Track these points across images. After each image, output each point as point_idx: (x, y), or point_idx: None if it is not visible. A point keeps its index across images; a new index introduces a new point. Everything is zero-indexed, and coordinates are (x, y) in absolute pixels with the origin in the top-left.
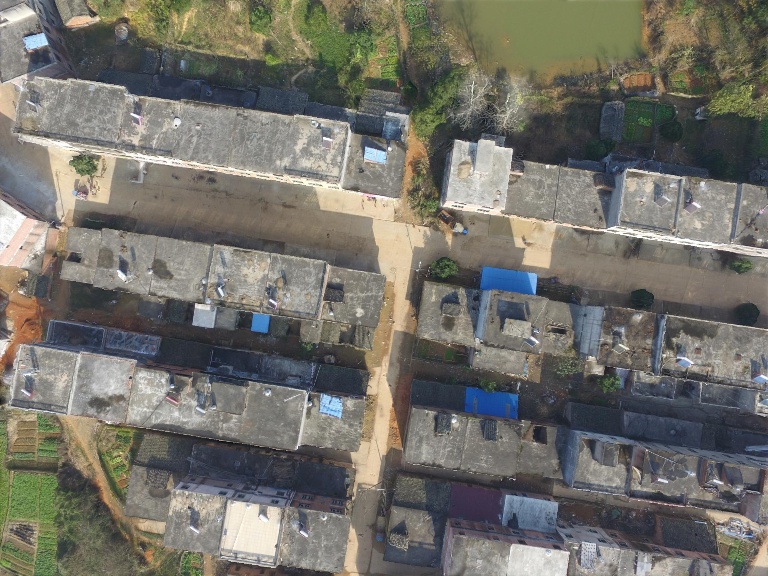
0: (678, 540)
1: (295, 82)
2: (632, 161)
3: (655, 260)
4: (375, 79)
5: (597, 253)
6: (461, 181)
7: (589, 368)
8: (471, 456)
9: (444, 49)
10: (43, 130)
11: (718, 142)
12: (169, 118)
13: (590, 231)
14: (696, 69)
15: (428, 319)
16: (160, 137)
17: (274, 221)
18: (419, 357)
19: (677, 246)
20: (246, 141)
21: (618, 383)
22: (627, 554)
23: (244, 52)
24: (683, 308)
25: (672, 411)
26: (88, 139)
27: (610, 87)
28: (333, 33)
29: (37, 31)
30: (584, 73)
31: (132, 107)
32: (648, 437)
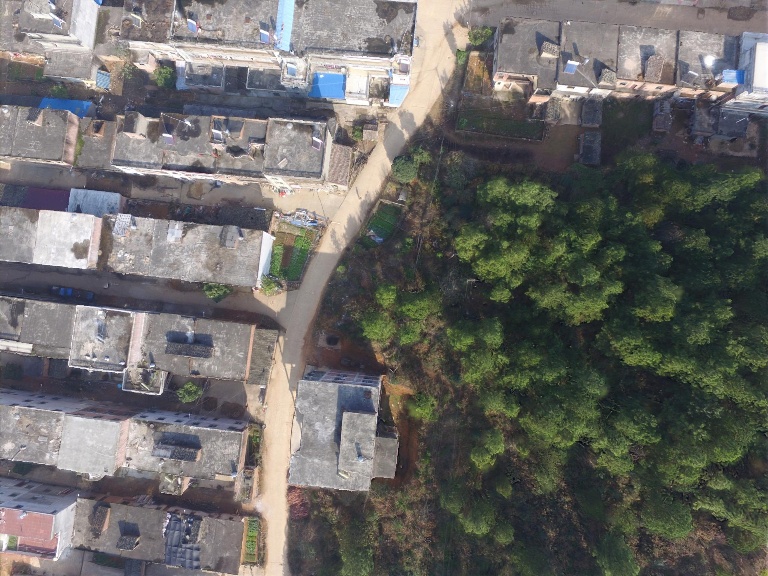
0: (231, 222)
1: None
2: None
3: None
4: None
5: None
6: None
7: (134, 58)
8: (21, 142)
9: None
10: None
11: None
12: None
13: None
14: None
15: (2, 32)
16: None
17: None
18: (12, 79)
19: None
20: None
21: (165, 72)
22: (161, 223)
23: None
24: None
25: None
26: None
27: None
28: None
29: None
30: None
31: None
32: None
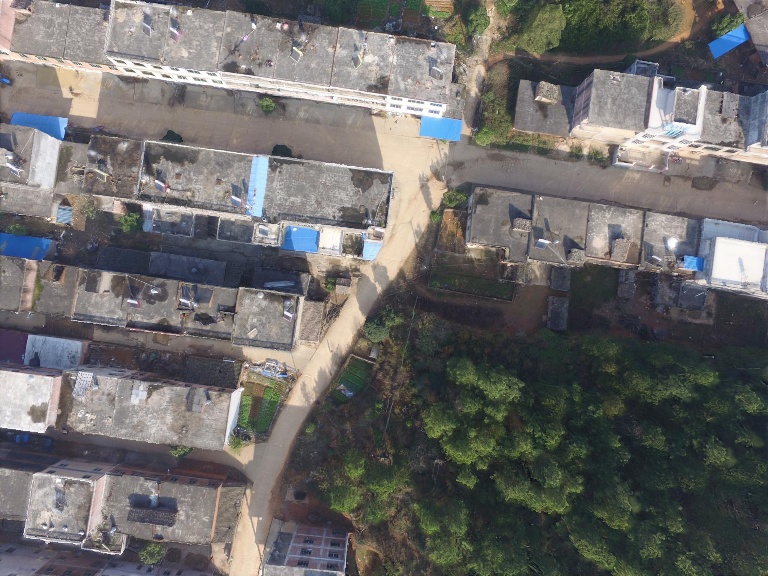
0: (198, 376)
1: None
2: None
3: (201, 108)
4: None
5: (144, 102)
6: None
7: (98, 204)
8: None
9: None
10: None
11: None
12: None
13: (130, 78)
14: None
15: None
16: None
17: None
18: None
19: (220, 93)
20: None
21: (131, 220)
22: (124, 383)
23: None
24: None
25: (213, 256)
26: None
27: None
28: None
29: None
30: None
31: None
32: (169, 275)
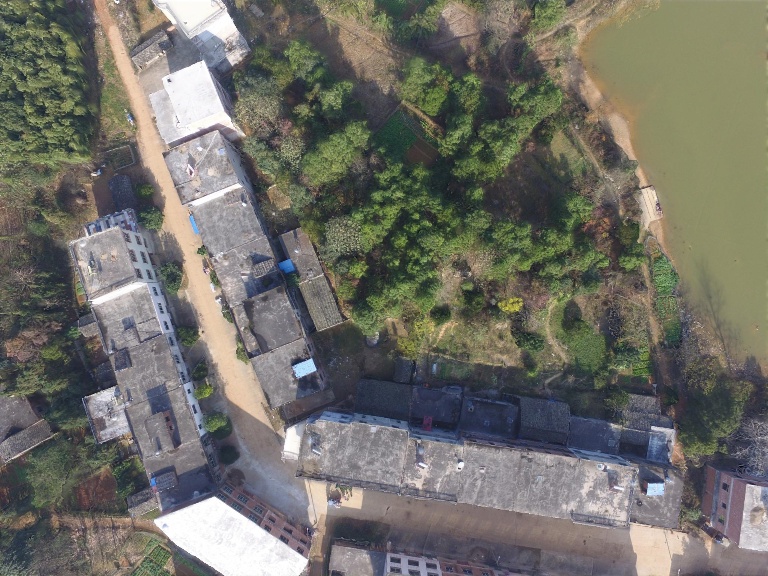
0: None
1: (549, 384)
2: None
3: None
4: (627, 376)
5: None
6: (754, 528)
7: None
8: None
9: (692, 339)
10: (325, 473)
11: None
12: (452, 461)
13: None
14: None
15: None
16: (444, 480)
17: (529, 527)
18: None
19: None
20: (531, 484)
21: None
22: None
23: (501, 360)
24: None
25: None
26: (371, 483)
27: None
28: (588, 335)
29: (305, 356)
30: None
31: (414, 449)
32: None
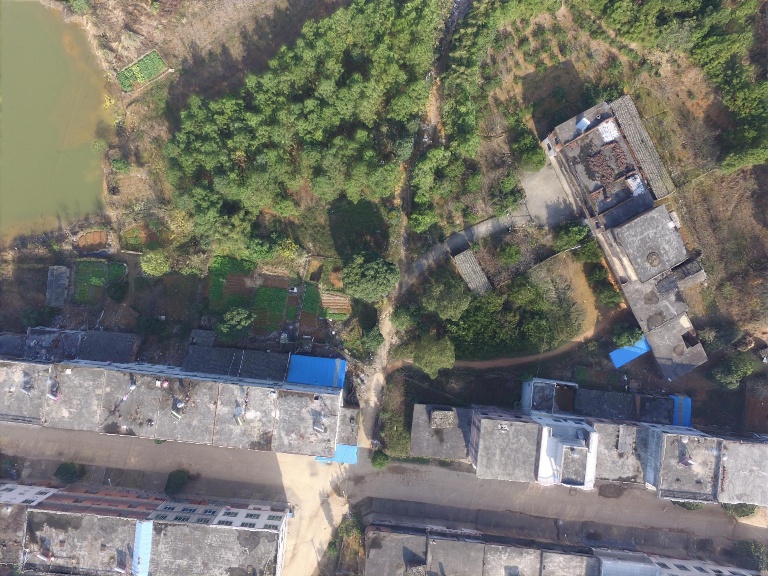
0: None
1: None
2: (50, 334)
3: None
4: None
5: None
6: None
7: None
8: None
9: None
10: None
11: (171, 298)
12: None
13: None
14: (150, 223)
15: None
16: None
17: None
18: None
19: None
20: None
21: None
22: None
23: None
24: (126, 474)
25: None
26: None
27: (62, 248)
28: None
29: None
30: (44, 232)
31: None
32: None
